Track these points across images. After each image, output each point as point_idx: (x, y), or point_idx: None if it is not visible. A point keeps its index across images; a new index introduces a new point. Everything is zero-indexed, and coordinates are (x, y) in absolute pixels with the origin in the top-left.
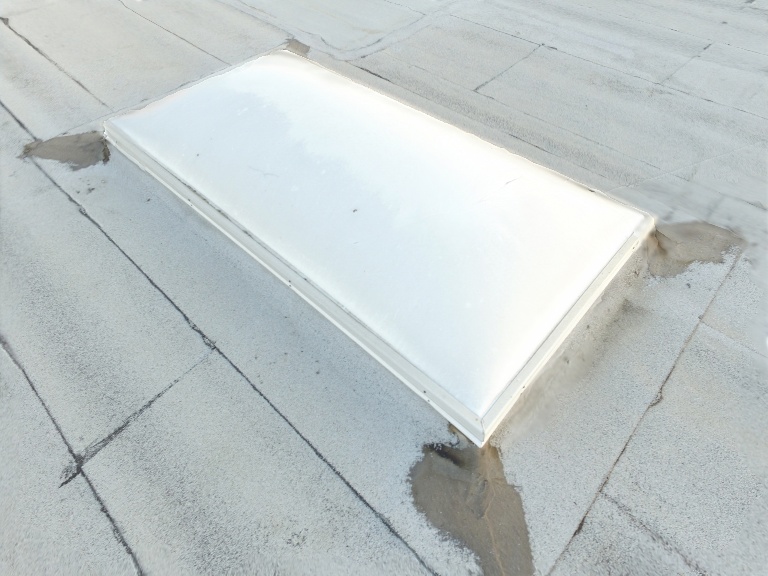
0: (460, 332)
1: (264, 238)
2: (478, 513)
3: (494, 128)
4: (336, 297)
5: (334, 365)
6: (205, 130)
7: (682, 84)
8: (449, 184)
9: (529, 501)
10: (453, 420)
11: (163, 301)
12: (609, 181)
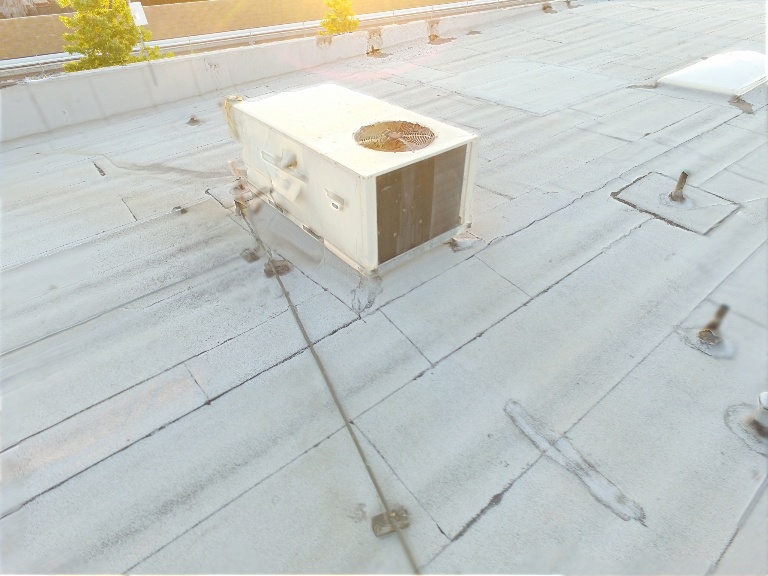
0: None
1: None
2: None
3: None
4: None
5: None
6: (743, 72)
7: None
8: None
9: None
10: None
11: None
12: None
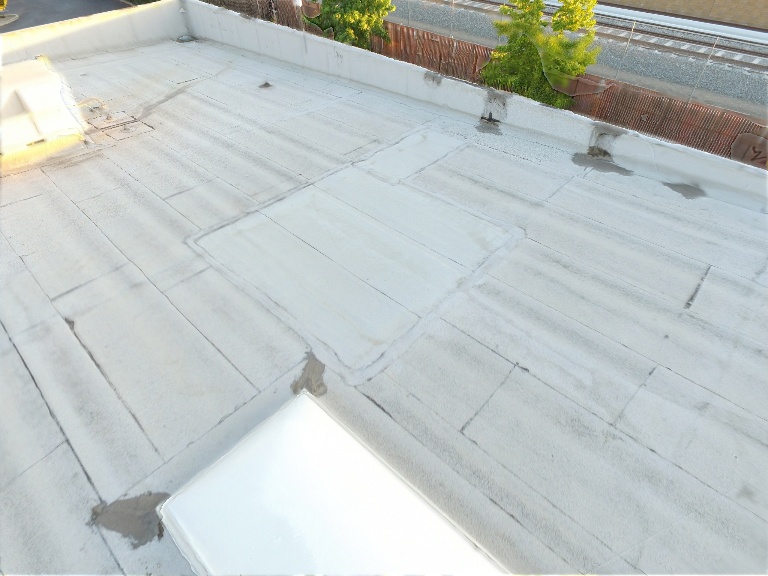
0: None
1: None
2: None
3: (477, 489)
4: None
5: None
6: (246, 546)
7: (631, 425)
8: (441, 572)
9: None
10: None
11: None
12: (570, 568)
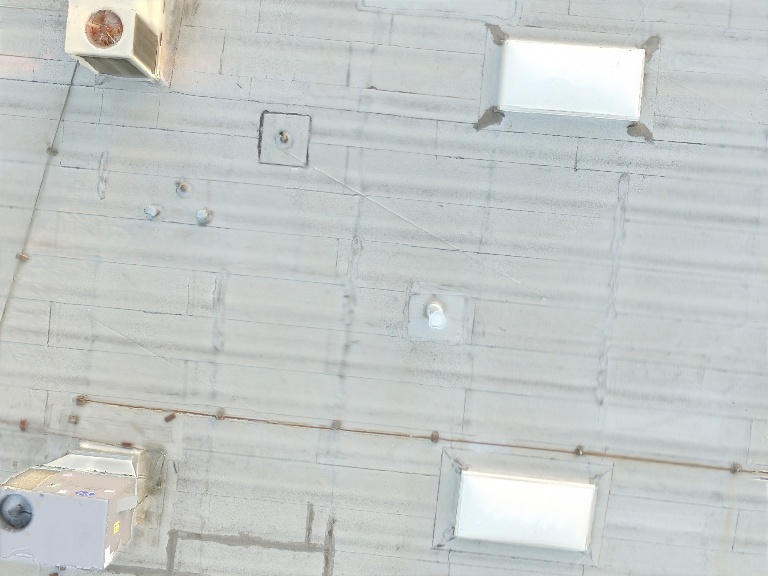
0: (629, 106)
1: (579, 111)
2: (640, 131)
3: (587, 31)
4: (602, 113)
5: (605, 125)
6: (542, 94)
7: None
8: None
9: (646, 124)
10: (633, 120)
11: (560, 137)
12: (626, 35)
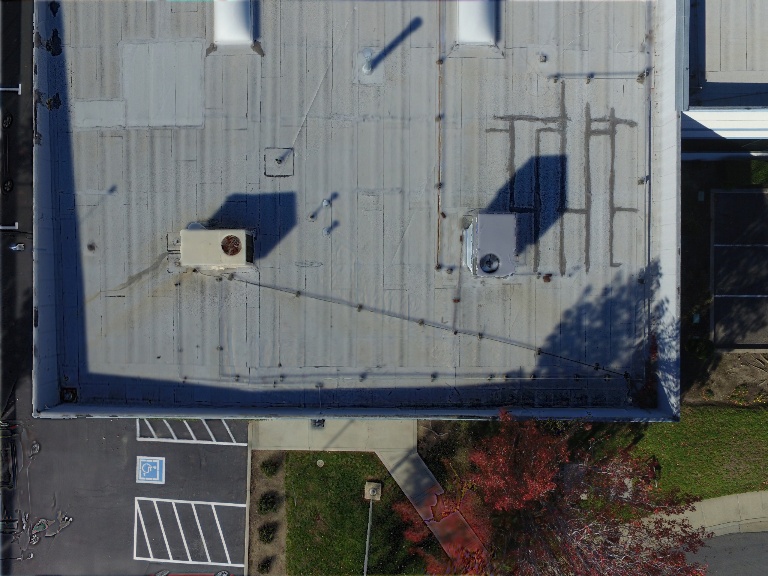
0: None
1: None
2: None
3: (206, 0)
4: None
5: None
6: None
7: None
8: None
9: None
10: None
11: (264, 8)
12: None
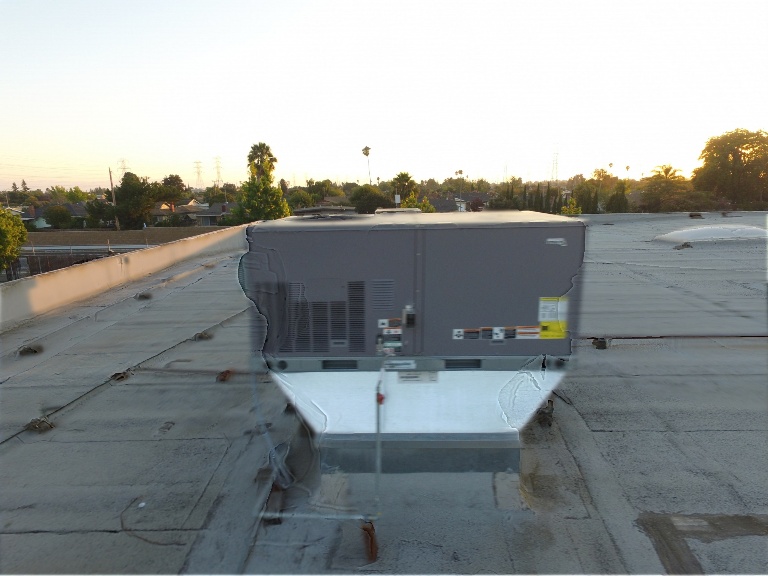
0: None
1: None
2: None
3: None
4: None
5: None
6: None
7: None
8: None
9: None
10: None
11: None
12: None
